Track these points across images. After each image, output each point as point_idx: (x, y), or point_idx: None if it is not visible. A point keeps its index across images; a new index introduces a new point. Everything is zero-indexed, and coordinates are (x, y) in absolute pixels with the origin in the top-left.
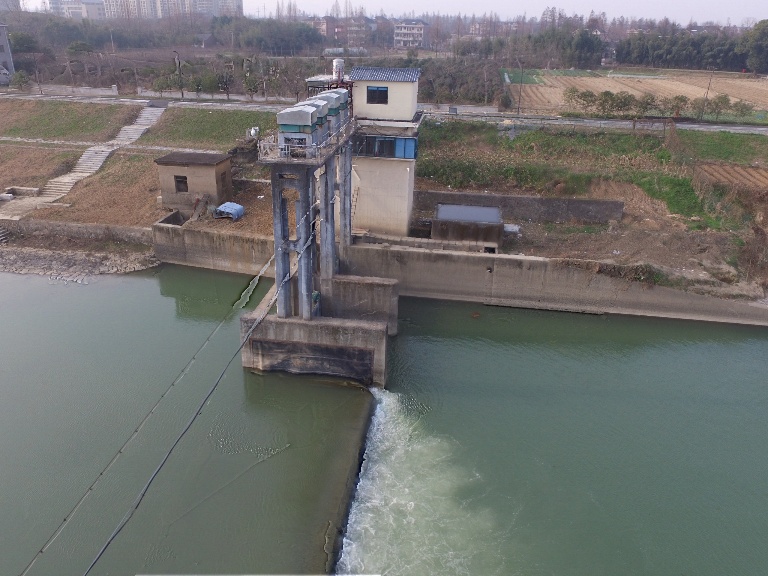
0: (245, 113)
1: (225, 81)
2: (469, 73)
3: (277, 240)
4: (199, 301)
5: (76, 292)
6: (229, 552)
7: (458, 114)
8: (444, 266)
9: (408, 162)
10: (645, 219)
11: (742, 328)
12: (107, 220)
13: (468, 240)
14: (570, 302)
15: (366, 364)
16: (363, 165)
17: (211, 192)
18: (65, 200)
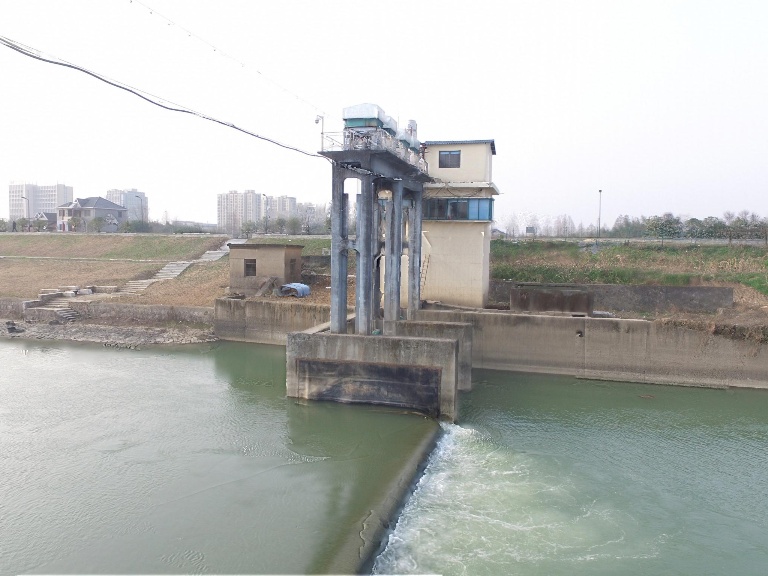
0: (323, 240)
1: (307, 221)
2: (545, 222)
3: (335, 237)
4: (253, 383)
5: (127, 356)
6: (227, 531)
7: (535, 237)
8: (526, 331)
9: (482, 225)
10: (762, 307)
11: None
12: (173, 303)
13: (552, 310)
14: (683, 373)
15: (431, 388)
16: (434, 231)
17: (279, 275)
18: (138, 292)
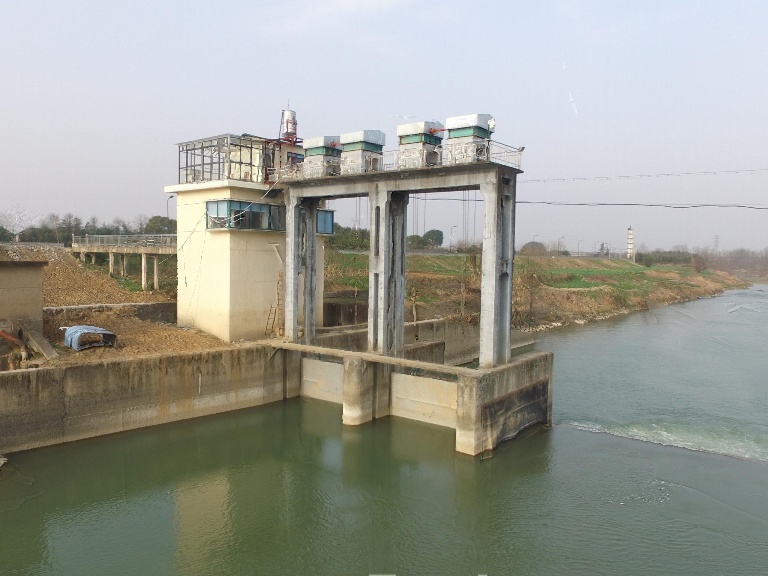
0: None
1: None
2: (38, 223)
3: (497, 260)
4: (82, 512)
5: None
6: None
7: None
8: None
9: None
10: None
11: (522, 350)
12: None
13: None
14: (458, 356)
15: (546, 399)
16: None
17: (31, 315)
18: None
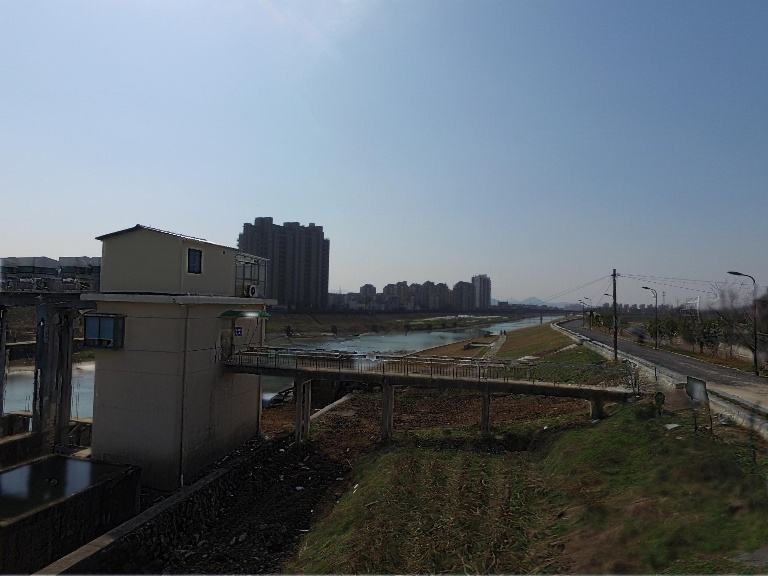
0: (590, 356)
1: None
2: None
3: None
4: None
5: None
6: None
7: None
8: None
9: None
10: None
11: None
12: None
13: None
14: None
15: None
16: None
17: None
18: None
